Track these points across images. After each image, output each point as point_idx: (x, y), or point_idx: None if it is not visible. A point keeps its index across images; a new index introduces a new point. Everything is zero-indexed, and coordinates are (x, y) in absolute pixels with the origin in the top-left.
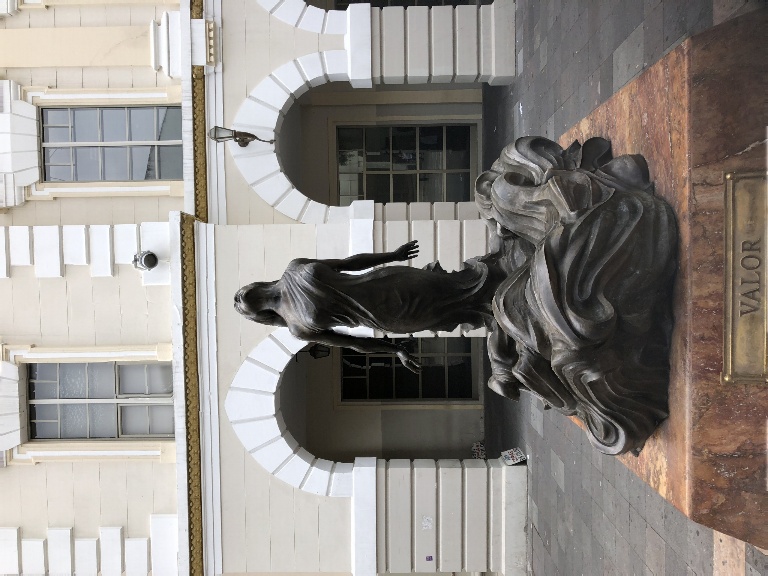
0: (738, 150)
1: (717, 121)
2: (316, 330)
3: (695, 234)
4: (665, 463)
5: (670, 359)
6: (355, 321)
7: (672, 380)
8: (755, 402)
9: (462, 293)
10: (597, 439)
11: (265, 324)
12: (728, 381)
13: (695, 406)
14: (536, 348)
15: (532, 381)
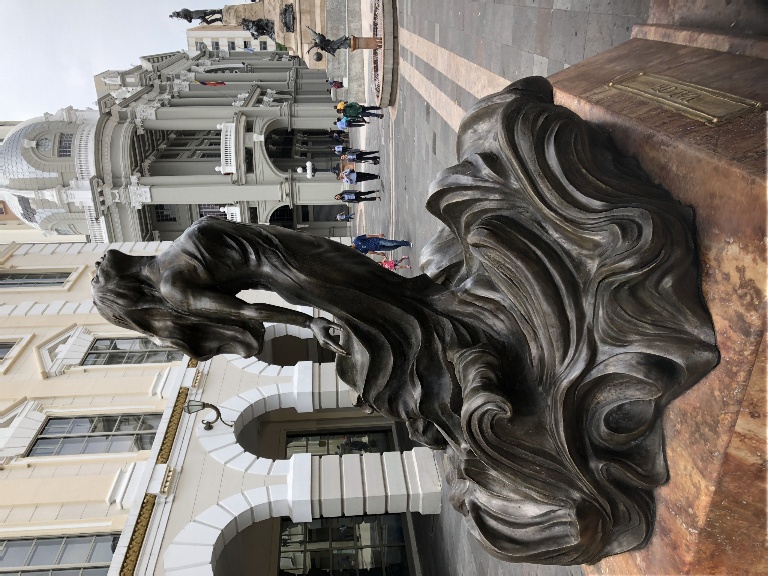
0: (609, 80)
1: (583, 82)
2: (199, 258)
3: (606, 105)
4: (733, 246)
5: (655, 180)
6: (254, 251)
7: (669, 182)
8: (764, 118)
9: (396, 276)
10: (617, 254)
11: (126, 306)
12: (718, 121)
13: (701, 144)
14: (482, 167)
15: (497, 232)
